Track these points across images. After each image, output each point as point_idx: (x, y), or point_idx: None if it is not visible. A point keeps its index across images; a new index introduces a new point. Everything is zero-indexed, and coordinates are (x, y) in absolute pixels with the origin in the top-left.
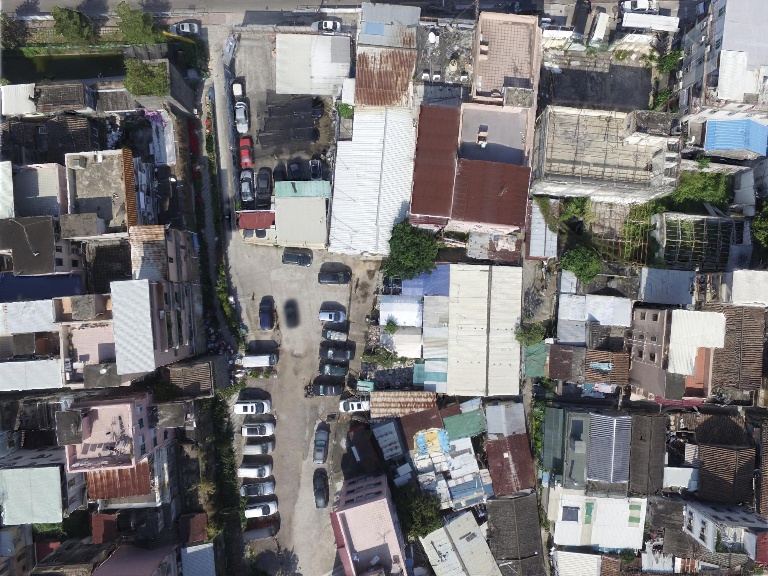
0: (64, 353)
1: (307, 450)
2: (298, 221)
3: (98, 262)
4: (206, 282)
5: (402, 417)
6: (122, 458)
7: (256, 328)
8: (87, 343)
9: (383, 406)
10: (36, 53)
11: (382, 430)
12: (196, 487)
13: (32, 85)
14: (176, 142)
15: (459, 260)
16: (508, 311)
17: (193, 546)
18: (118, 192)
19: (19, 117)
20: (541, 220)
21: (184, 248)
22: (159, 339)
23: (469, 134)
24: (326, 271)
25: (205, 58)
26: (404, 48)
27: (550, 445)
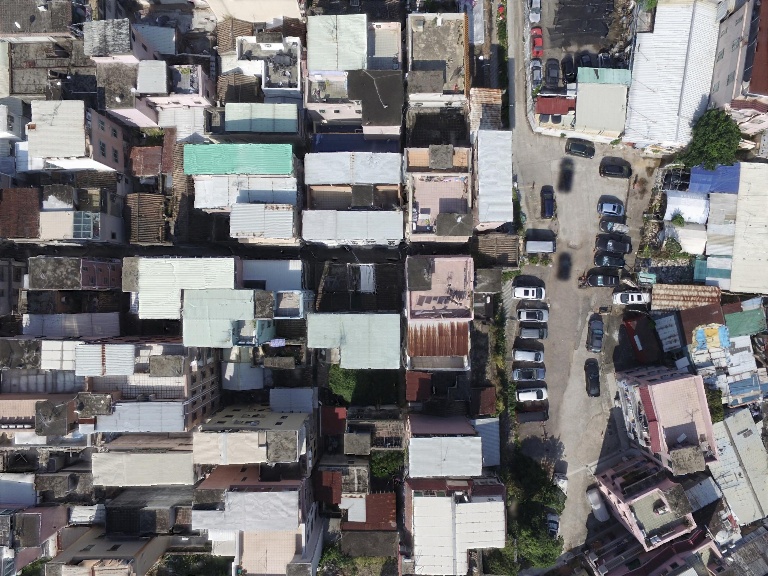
0: None
1: (579, 340)
2: (598, 107)
3: (417, 128)
4: None
5: (683, 311)
6: (456, 312)
7: (534, 217)
8: (429, 197)
9: (665, 298)
10: None
11: (663, 322)
12: (484, 362)
13: None
14: (485, 21)
15: None
16: None
17: (481, 419)
18: (453, 57)
19: None
20: None
21: None
22: None
23: None
24: None
25: None
26: None
27: None
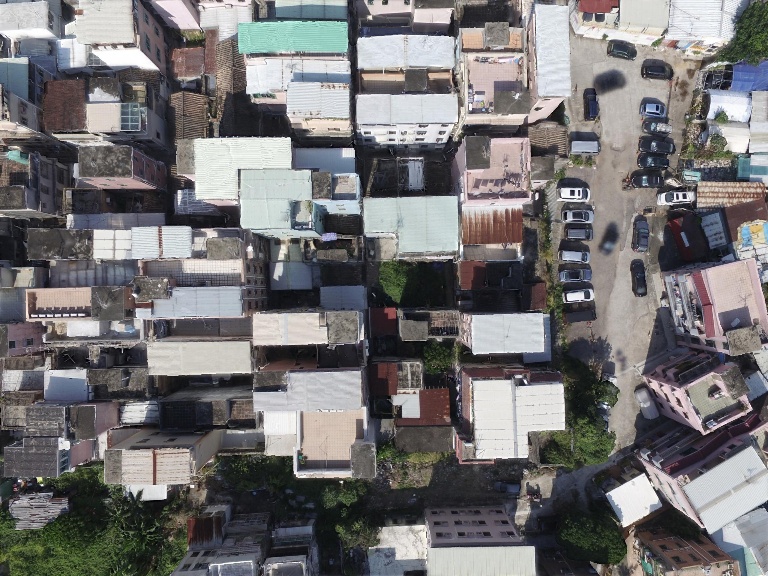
0: (467, 84)
1: (624, 241)
2: (642, 4)
3: (465, 20)
4: None
5: (728, 208)
6: (512, 195)
7: (577, 119)
8: (483, 79)
9: (710, 196)
10: None
11: (708, 219)
12: (533, 259)
13: None
14: None
15: None
16: None
17: None
18: None
19: None
20: None
21: None
22: None
23: None
24: None
25: None
26: None
27: None
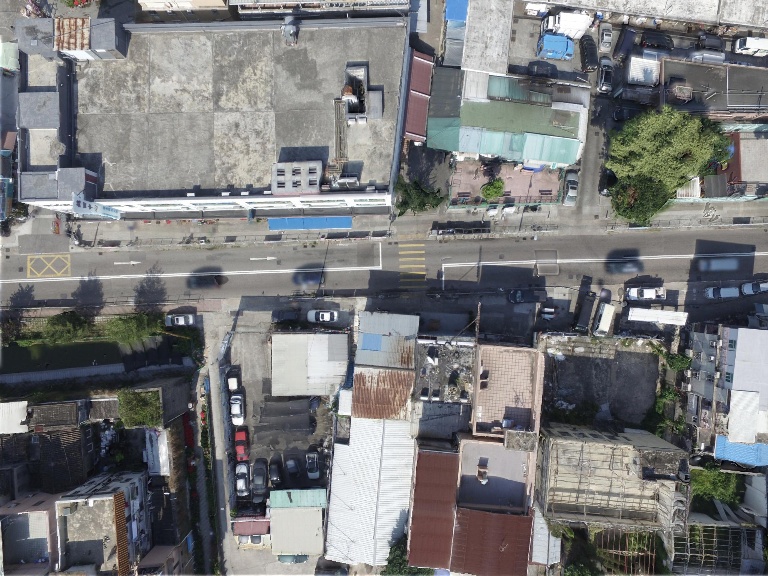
0: None
1: None
2: (294, 532)
3: None
4: None
5: None
6: None
7: None
8: None
9: None
10: (30, 343)
11: None
12: None
13: (24, 403)
14: (170, 453)
15: None
16: None
17: None
18: (109, 535)
19: (11, 435)
20: (544, 526)
21: (178, 563)
22: None
23: (469, 467)
24: (323, 566)
25: (200, 347)
26: (402, 369)
27: None
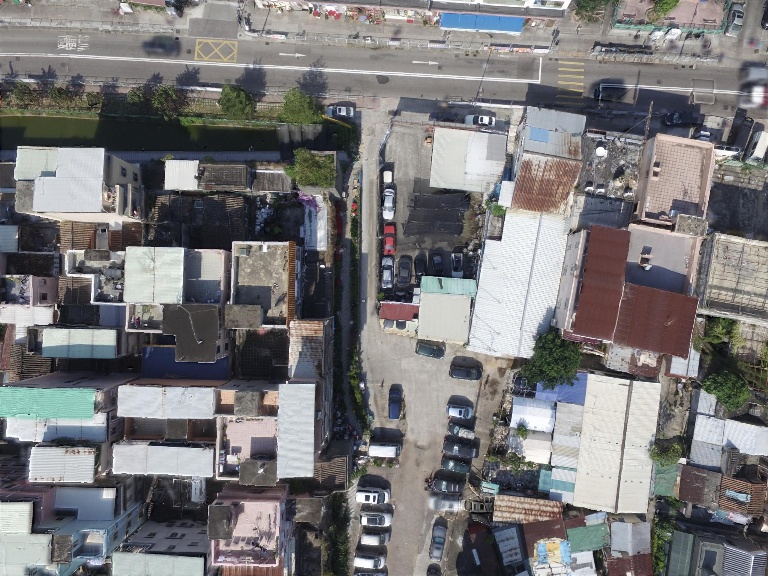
0: (220, 445)
1: (423, 544)
2: (441, 318)
3: (247, 346)
4: (338, 365)
5: (525, 523)
6: None
7: (382, 415)
8: (241, 435)
9: (507, 510)
10: (192, 122)
11: (504, 534)
12: (316, 575)
13: (196, 162)
14: (329, 228)
15: (592, 366)
16: (644, 428)
17: None
18: (279, 282)
19: (180, 192)
20: None
21: None
22: (314, 440)
23: (632, 254)
24: (458, 365)
25: (357, 141)
26: (570, 159)
27: (676, 570)
